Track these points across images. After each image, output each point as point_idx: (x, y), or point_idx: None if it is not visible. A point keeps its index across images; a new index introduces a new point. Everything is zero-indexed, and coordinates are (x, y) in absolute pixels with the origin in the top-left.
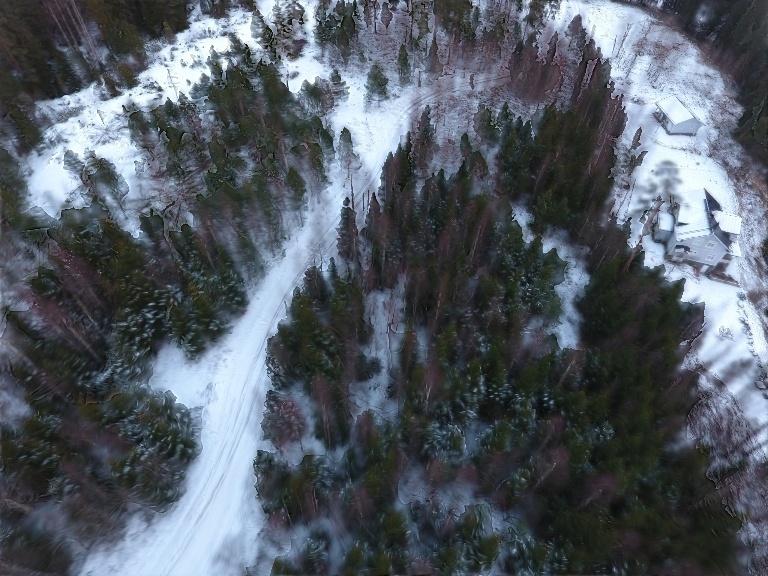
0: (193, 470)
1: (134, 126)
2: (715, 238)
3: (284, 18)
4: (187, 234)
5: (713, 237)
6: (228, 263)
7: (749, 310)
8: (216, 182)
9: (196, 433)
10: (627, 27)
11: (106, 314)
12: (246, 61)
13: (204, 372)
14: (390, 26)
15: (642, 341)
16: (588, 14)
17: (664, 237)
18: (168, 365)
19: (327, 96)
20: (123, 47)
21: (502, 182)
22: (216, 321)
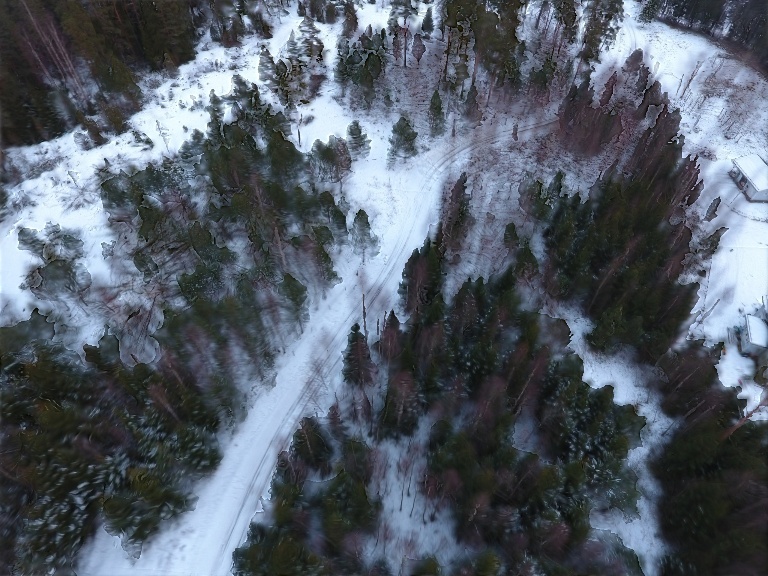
0: None
1: (106, 197)
2: None
3: (300, 54)
4: (141, 377)
5: None
6: (195, 411)
7: None
8: (192, 288)
9: None
10: (697, 65)
11: (25, 489)
12: (254, 102)
13: (152, 569)
14: (422, 58)
15: (764, 575)
16: (645, 43)
17: (755, 351)
18: (107, 553)
19: (343, 158)
20: (113, 86)
21: (555, 284)
22: (170, 506)
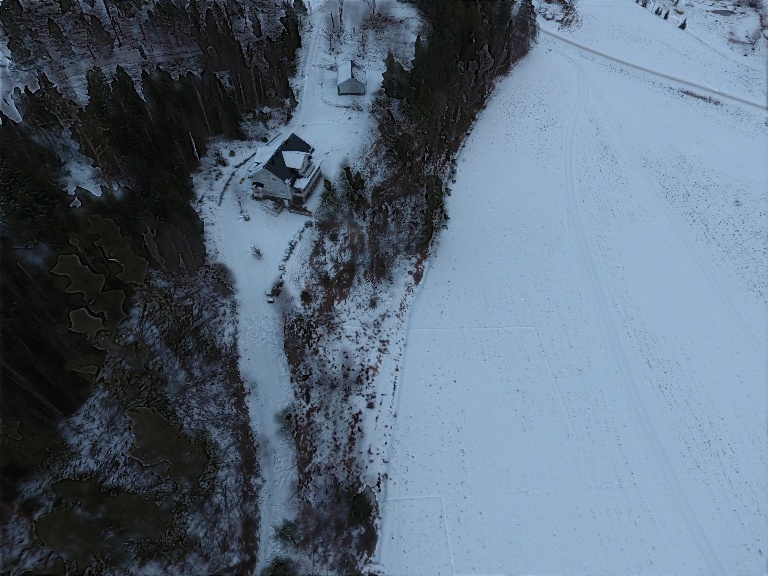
0: None
1: None
2: (268, 172)
3: None
4: None
5: (266, 171)
6: None
7: (308, 235)
8: None
9: None
10: None
11: None
12: None
13: None
14: (105, 8)
15: None
16: None
17: None
18: None
19: None
20: None
21: (71, 131)
22: None
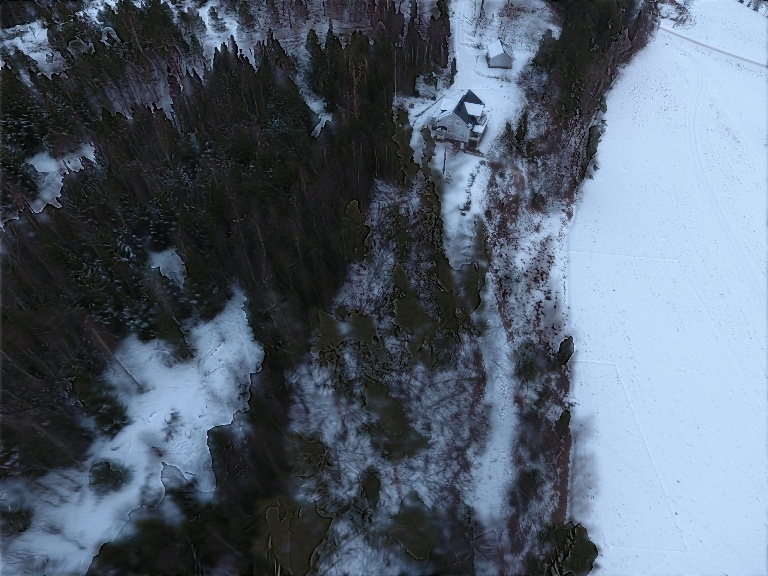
0: (35, 203)
1: (50, 34)
2: (456, 116)
3: None
4: (55, 80)
5: (455, 115)
6: (84, 102)
7: (483, 170)
8: None
9: (38, 181)
10: None
11: None
12: None
13: (59, 164)
14: None
15: None
16: None
17: None
18: (38, 161)
19: (198, 22)
20: None
21: (304, 75)
22: (66, 130)
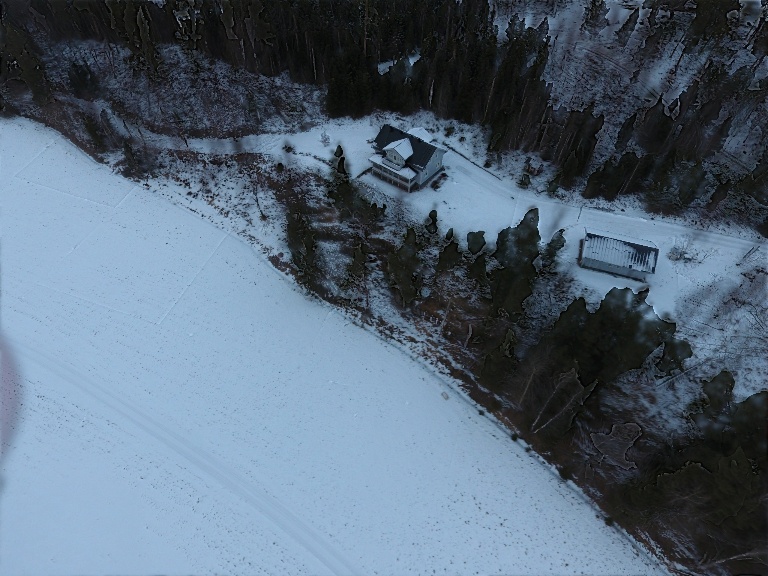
0: None
1: None
2: None
3: None
4: None
5: None
6: None
7: (336, 174)
8: None
9: None
10: None
11: None
12: None
13: None
14: None
15: None
16: None
17: None
18: None
19: None
20: None
21: None
22: None
